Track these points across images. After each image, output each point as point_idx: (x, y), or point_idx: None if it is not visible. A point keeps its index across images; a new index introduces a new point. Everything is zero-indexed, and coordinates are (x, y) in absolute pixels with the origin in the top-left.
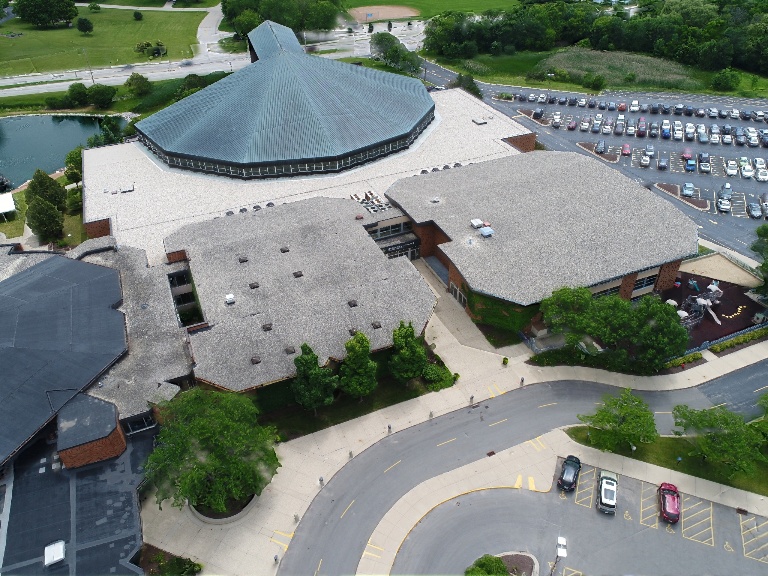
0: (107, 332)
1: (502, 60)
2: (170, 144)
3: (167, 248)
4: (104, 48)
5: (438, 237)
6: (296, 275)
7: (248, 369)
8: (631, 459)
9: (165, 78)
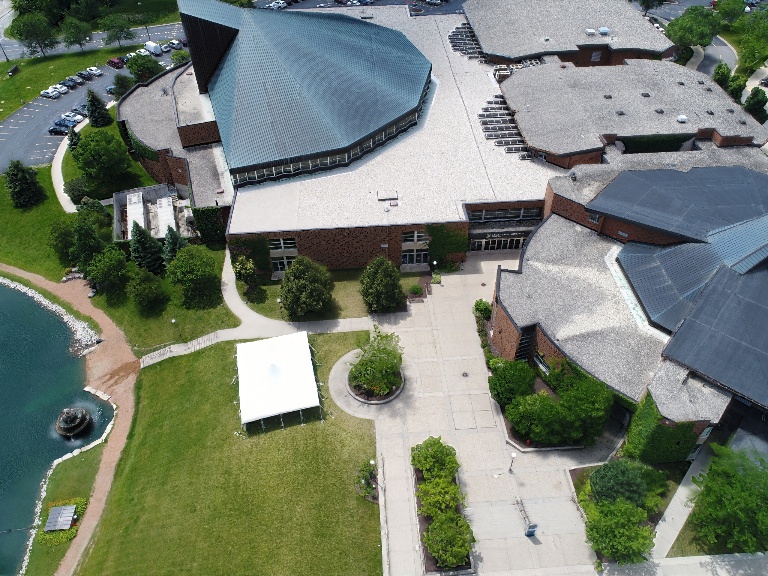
0: (724, 172)
1: (133, 4)
2: (338, 140)
3: (587, 148)
4: None
5: (568, 60)
6: (649, 95)
7: (751, 126)
8: (757, 70)
9: None
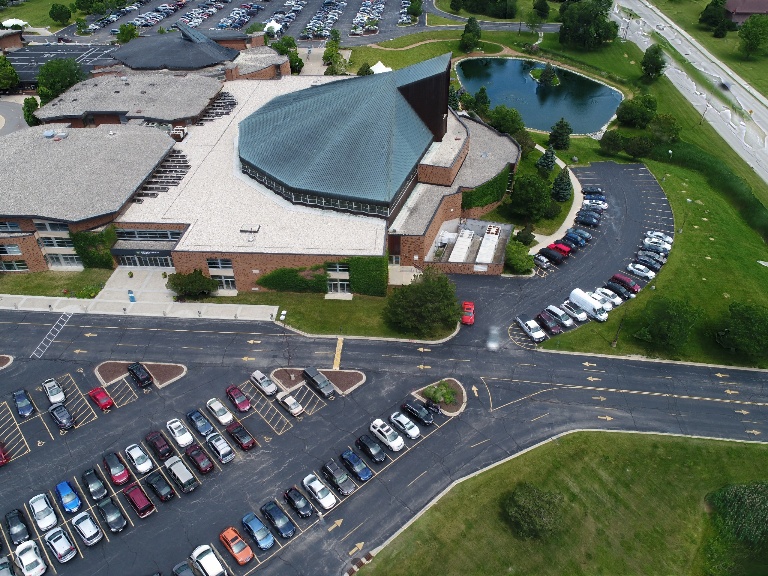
0: None
1: None
2: None
3: None
4: (726, 88)
5: None
6: (116, 91)
7: None
8: None
9: (753, 161)
